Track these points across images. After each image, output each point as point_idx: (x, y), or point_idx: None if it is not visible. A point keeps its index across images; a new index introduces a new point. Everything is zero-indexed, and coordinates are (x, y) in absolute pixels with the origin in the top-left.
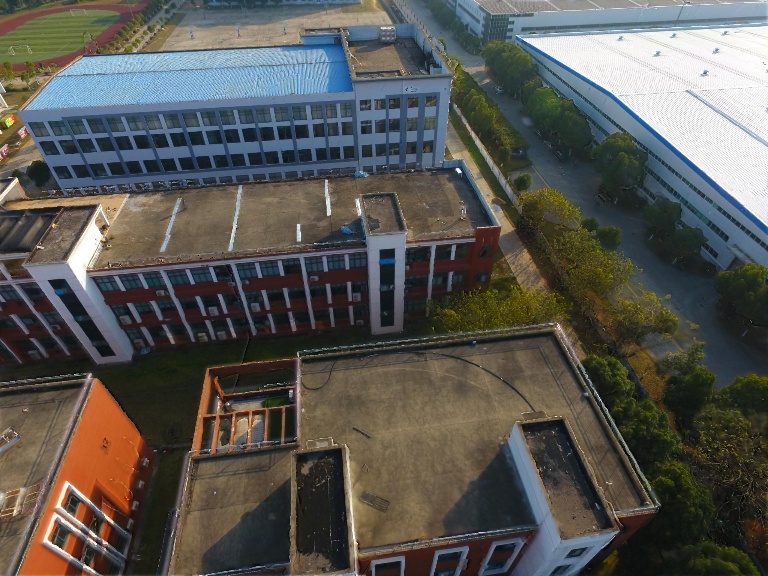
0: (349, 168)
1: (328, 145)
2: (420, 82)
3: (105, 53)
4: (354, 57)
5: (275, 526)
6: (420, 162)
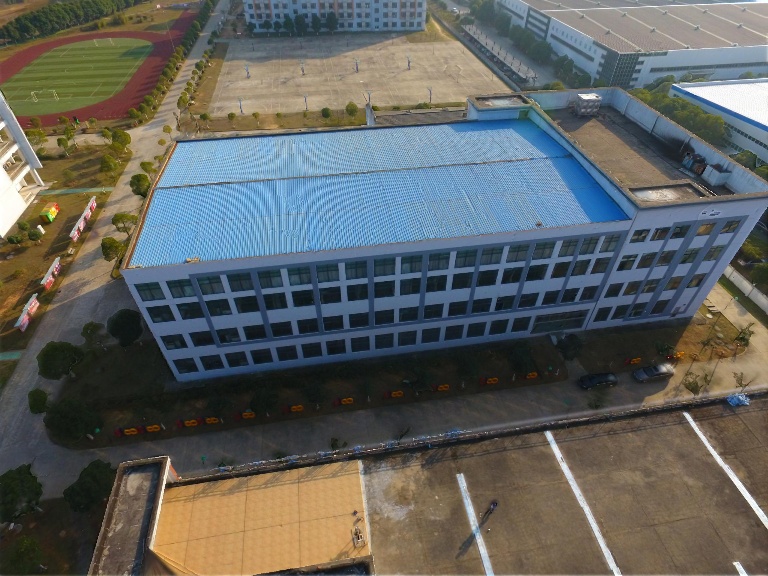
0: (579, 311)
1: (565, 286)
2: (731, 204)
3: (207, 137)
4: None
5: None
6: (676, 298)
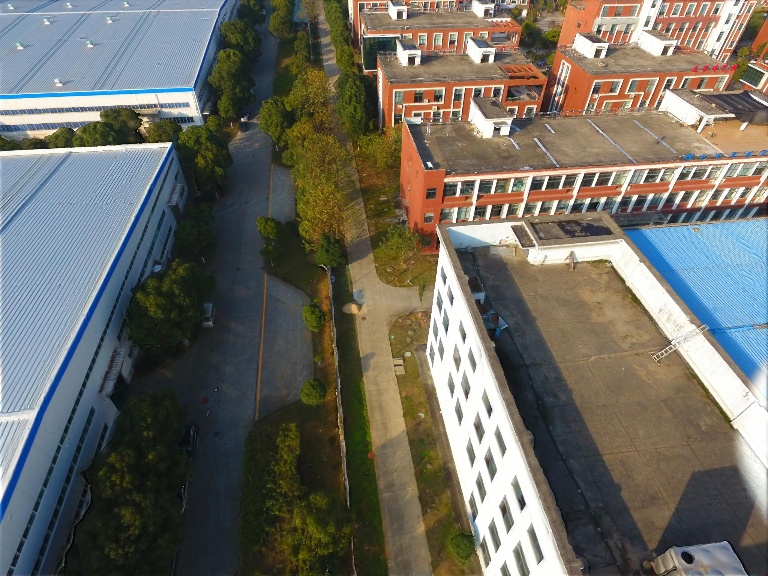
0: None
1: None
2: None
3: None
4: (681, 340)
5: (495, 57)
6: None
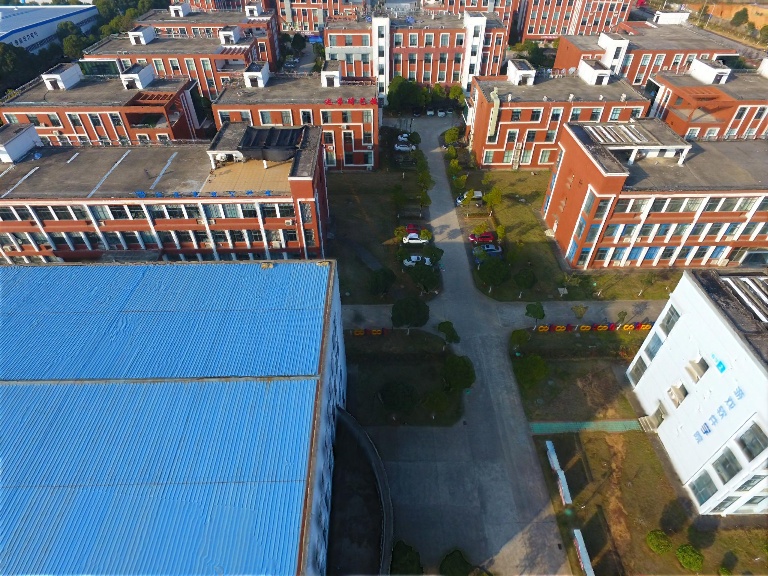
0: None
1: None
2: None
3: None
4: None
5: None
6: None
